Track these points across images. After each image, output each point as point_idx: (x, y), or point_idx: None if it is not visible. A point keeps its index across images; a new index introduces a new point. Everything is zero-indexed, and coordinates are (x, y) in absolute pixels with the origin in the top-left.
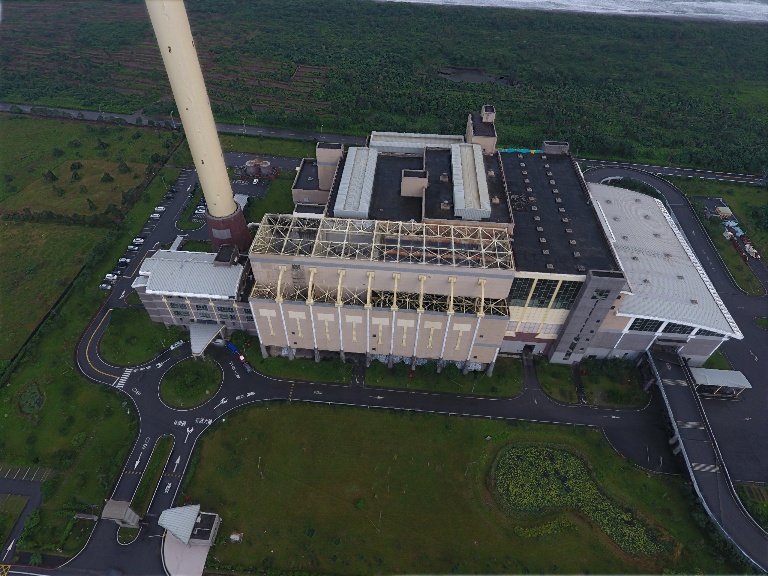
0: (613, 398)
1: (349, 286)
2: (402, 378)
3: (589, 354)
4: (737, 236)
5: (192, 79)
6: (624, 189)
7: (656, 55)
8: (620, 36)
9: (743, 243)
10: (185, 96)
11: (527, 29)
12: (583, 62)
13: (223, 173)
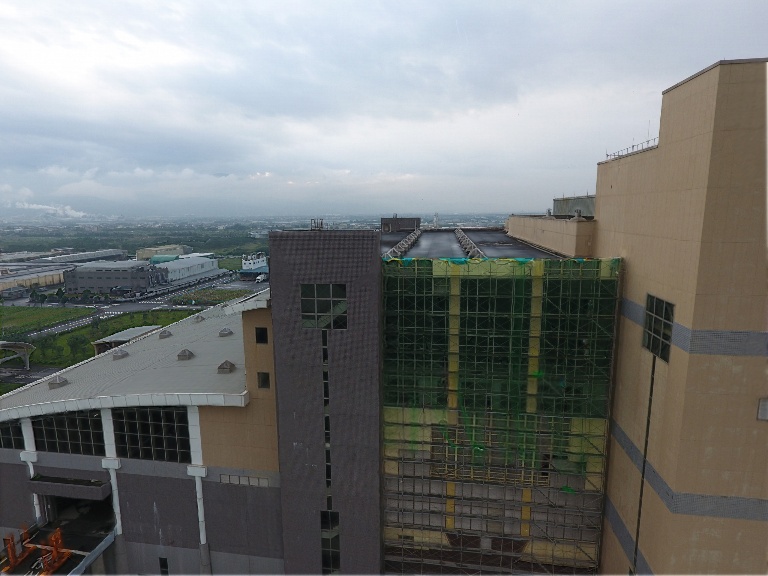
0: None
1: None
2: None
3: None
4: None
5: None
6: (34, 405)
7: None
8: None
9: None
10: None
11: None
12: None
13: None
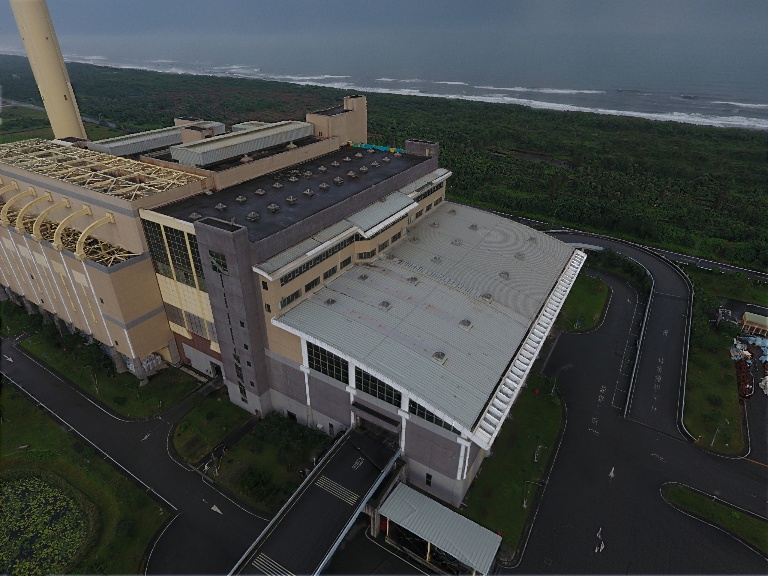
0: (243, 479)
1: (30, 209)
2: (55, 350)
3: (285, 408)
4: (759, 360)
5: (24, 7)
6: None
7: None
8: None
9: (763, 372)
10: (20, 24)
11: (640, 132)
12: (690, 162)
13: (67, 117)
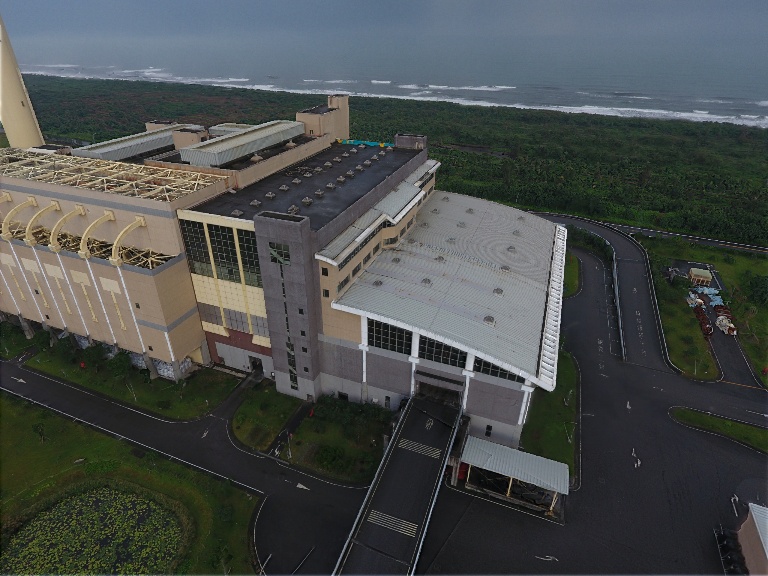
0: (320, 456)
1: (24, 221)
2: (71, 366)
3: (336, 390)
4: (710, 305)
5: None
6: None
7: (707, 148)
8: (669, 133)
9: (716, 314)
10: None
11: (560, 123)
12: (608, 148)
13: (25, 125)
